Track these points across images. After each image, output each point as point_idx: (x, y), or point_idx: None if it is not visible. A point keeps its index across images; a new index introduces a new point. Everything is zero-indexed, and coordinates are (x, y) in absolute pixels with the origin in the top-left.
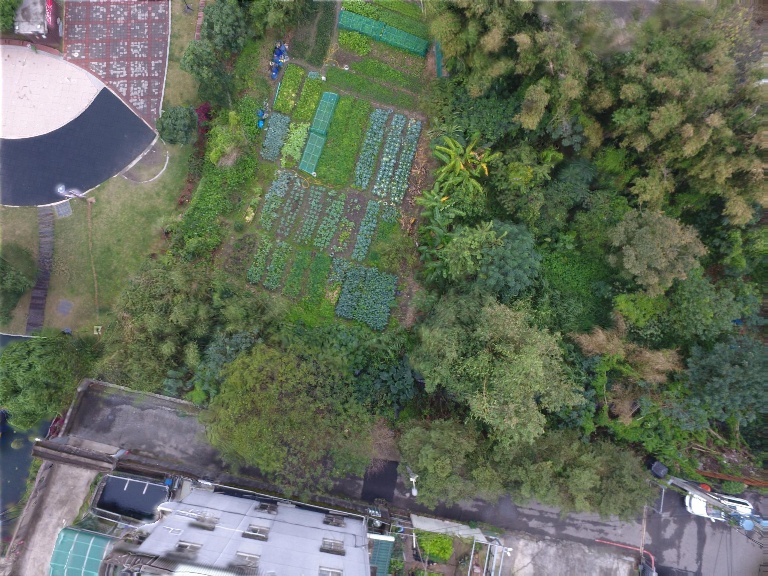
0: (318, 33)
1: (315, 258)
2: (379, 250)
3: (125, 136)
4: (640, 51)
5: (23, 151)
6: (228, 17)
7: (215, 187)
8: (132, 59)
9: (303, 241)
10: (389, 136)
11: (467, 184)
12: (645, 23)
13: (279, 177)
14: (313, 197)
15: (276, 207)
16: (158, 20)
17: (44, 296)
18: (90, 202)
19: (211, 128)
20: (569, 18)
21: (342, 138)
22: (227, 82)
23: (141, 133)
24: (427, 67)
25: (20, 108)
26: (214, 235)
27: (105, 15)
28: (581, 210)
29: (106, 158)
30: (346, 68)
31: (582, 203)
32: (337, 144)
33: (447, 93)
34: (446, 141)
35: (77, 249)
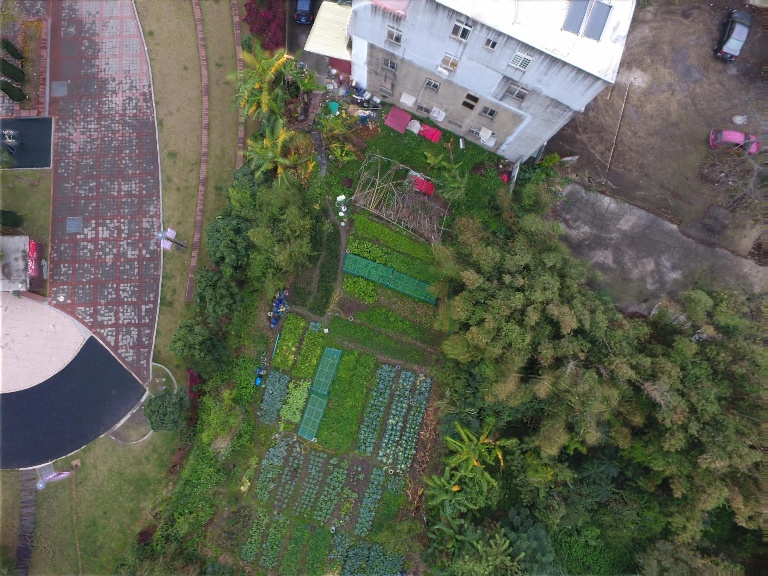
0: (320, 278)
1: (315, 534)
2: (384, 540)
3: (113, 392)
4: (671, 300)
5: (4, 408)
6: (222, 297)
7: (208, 459)
8: (121, 303)
9: (302, 514)
10: (396, 396)
11: (481, 481)
12: (676, 263)
13: (277, 443)
14: (313, 464)
15: (273, 476)
16: (149, 258)
17: (25, 575)
18: (75, 466)
19: (204, 392)
20: (593, 258)
21: (345, 397)
22: (221, 355)
23: (130, 389)
24: (438, 316)
25: (2, 359)
26: (206, 509)
27: (93, 253)
28: (605, 509)
29: (92, 416)
30: (350, 320)
31: (607, 506)
32: (340, 404)
33: (460, 370)
34: (458, 430)
35: (60, 523)
